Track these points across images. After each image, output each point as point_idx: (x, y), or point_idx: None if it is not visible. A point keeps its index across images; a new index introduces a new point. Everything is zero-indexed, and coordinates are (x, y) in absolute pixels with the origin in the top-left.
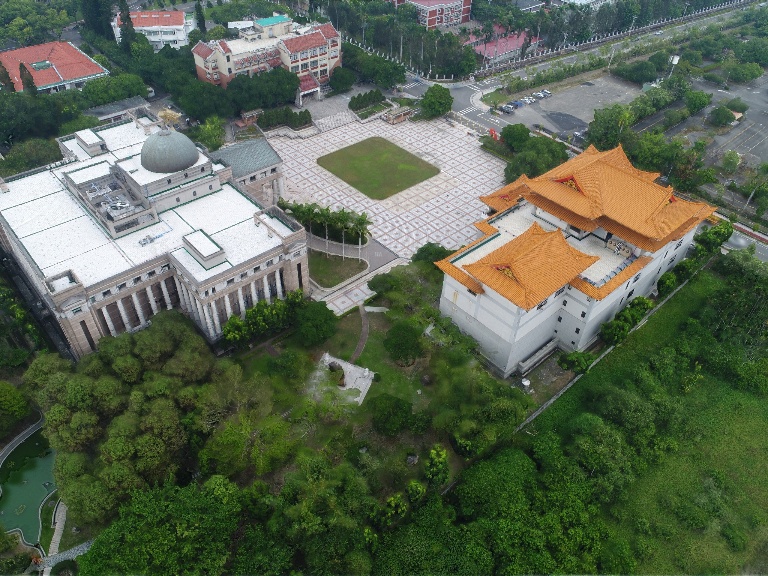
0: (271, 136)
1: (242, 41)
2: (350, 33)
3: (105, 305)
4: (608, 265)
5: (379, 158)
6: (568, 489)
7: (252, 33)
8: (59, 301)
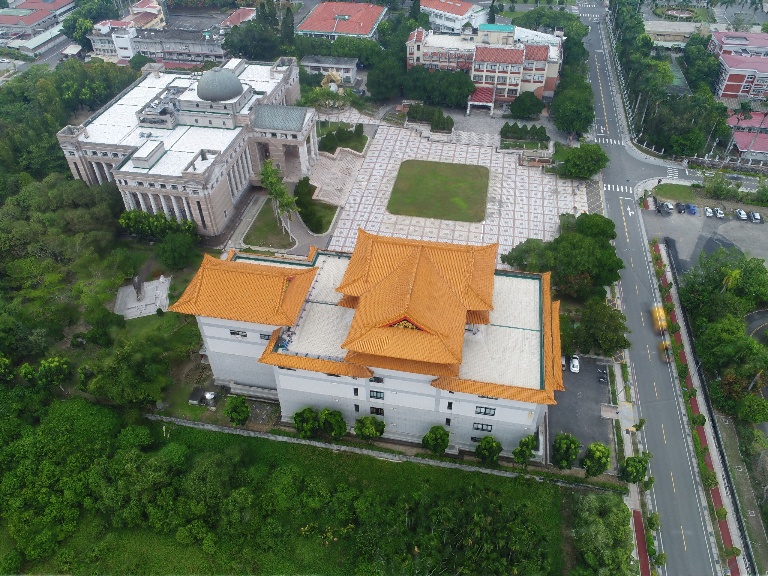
0: (410, 127)
1: (458, 38)
2: (625, 71)
3: (94, 161)
4: (329, 349)
5: (452, 184)
6: (89, 470)
7: (465, 33)
8: (61, 141)
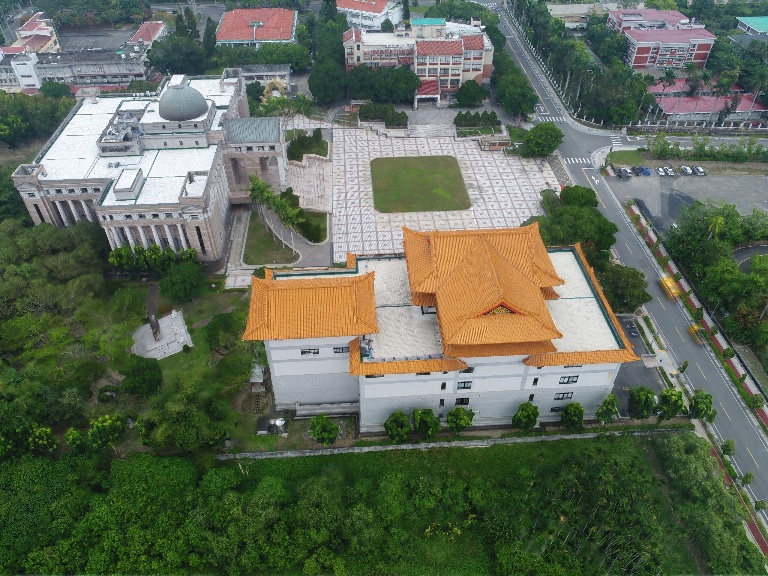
0: (364, 127)
1: (391, 35)
2: (543, 53)
3: (58, 200)
4: (413, 349)
5: (428, 176)
6: (185, 525)
7: (400, 29)
8: (18, 182)
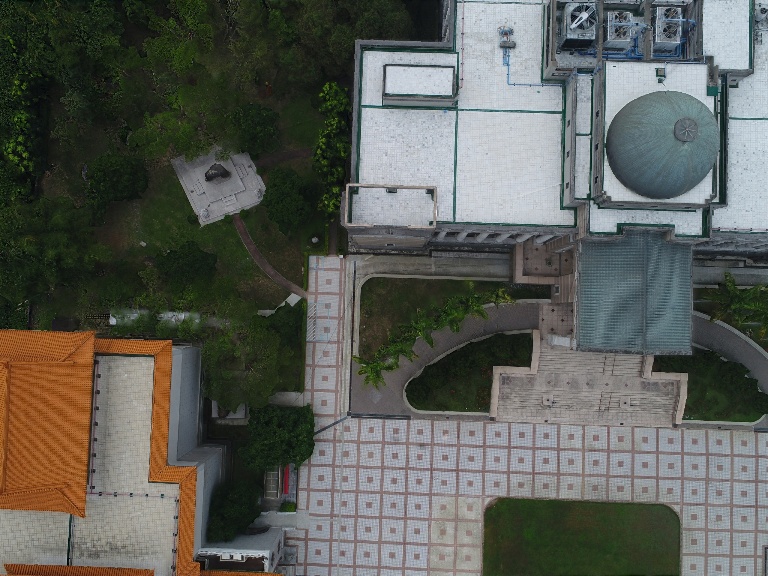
0: None
1: None
2: None
3: None
4: None
5: None
6: None
7: None
8: None
